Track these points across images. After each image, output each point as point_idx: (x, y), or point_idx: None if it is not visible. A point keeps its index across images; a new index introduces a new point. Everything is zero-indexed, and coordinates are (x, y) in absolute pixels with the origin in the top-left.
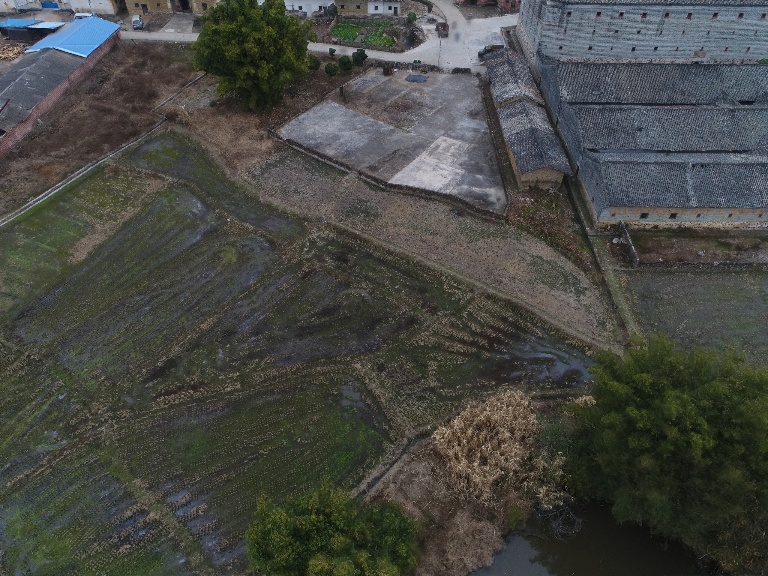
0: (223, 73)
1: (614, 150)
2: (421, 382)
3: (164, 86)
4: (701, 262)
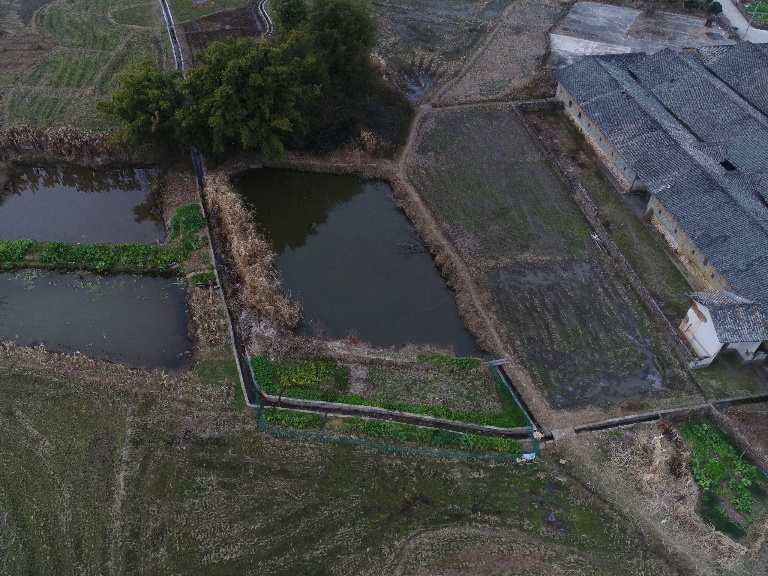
0: None
1: None
2: (390, 53)
3: None
4: None
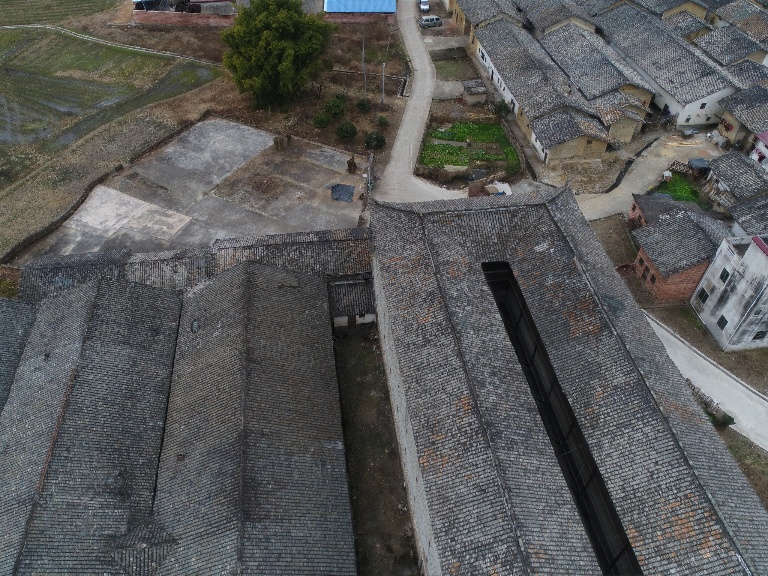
0: None
1: None
2: None
3: None
4: None
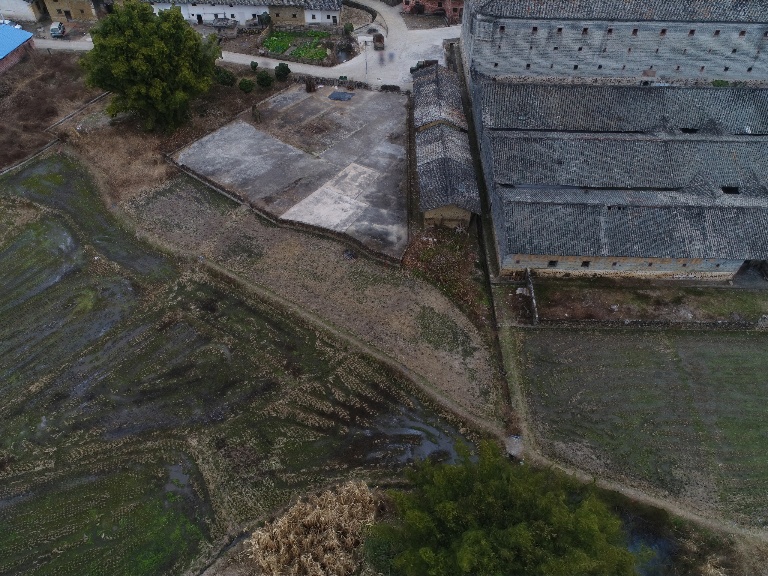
0: (119, 90)
1: (529, 185)
2: (261, 464)
3: (66, 102)
4: (609, 320)
